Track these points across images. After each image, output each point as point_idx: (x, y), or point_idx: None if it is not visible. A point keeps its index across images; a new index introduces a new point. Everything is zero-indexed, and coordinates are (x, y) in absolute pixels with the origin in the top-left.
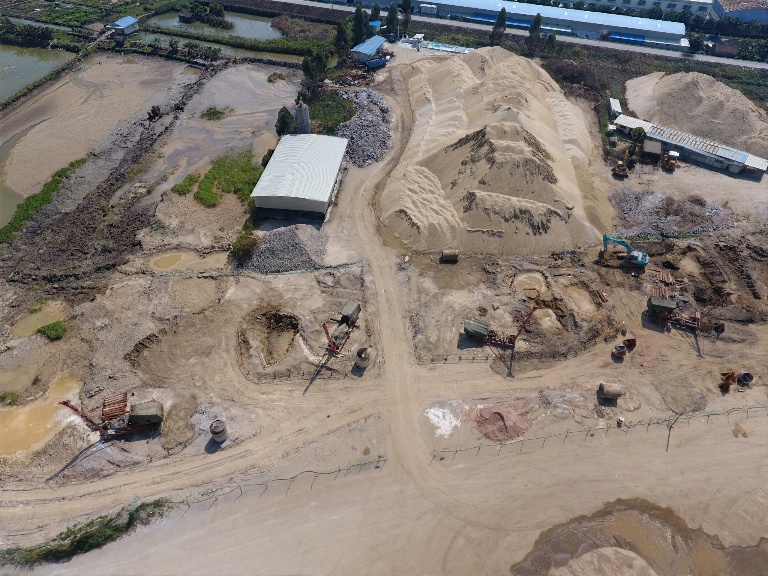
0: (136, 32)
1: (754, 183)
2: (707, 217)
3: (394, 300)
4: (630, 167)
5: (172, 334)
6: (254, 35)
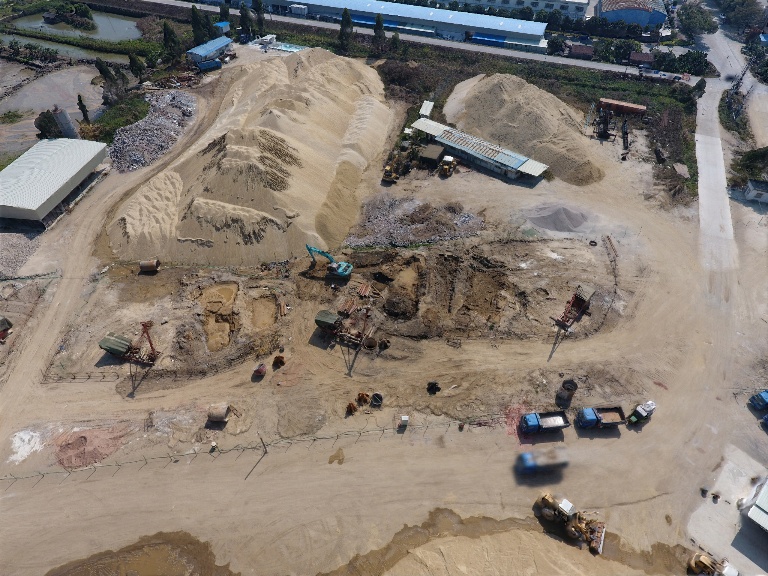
0: None
1: (526, 189)
2: (450, 225)
3: (63, 314)
4: (405, 172)
5: None
6: (115, 36)
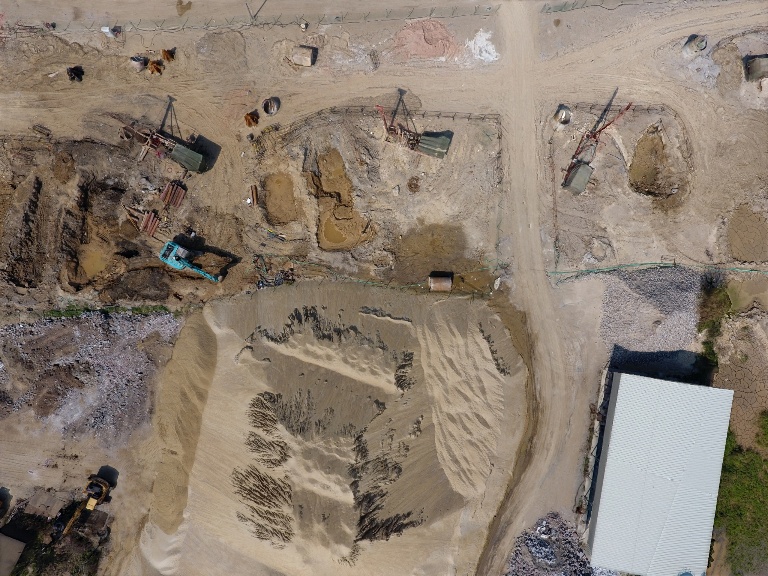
0: None
1: None
2: (8, 355)
3: (519, 211)
4: (70, 509)
5: (762, 176)
6: None
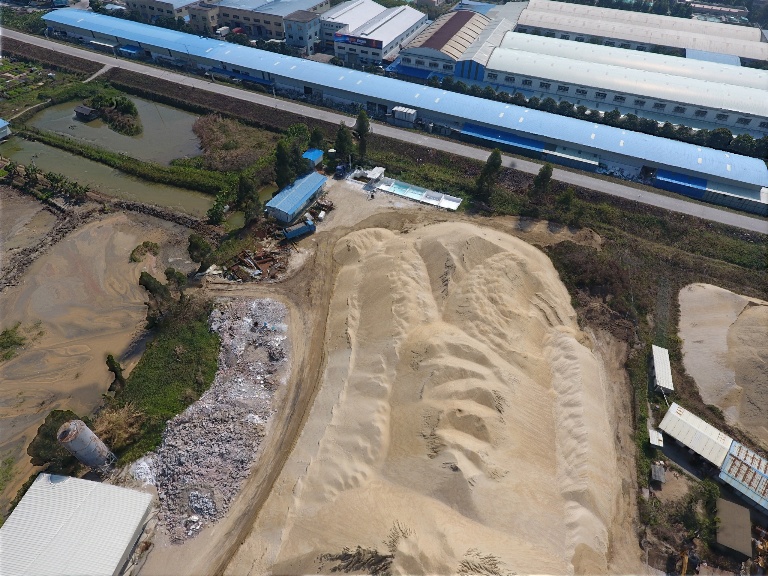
0: (7, 138)
1: None
2: None
3: None
4: (689, 574)
5: None
6: (165, 145)
